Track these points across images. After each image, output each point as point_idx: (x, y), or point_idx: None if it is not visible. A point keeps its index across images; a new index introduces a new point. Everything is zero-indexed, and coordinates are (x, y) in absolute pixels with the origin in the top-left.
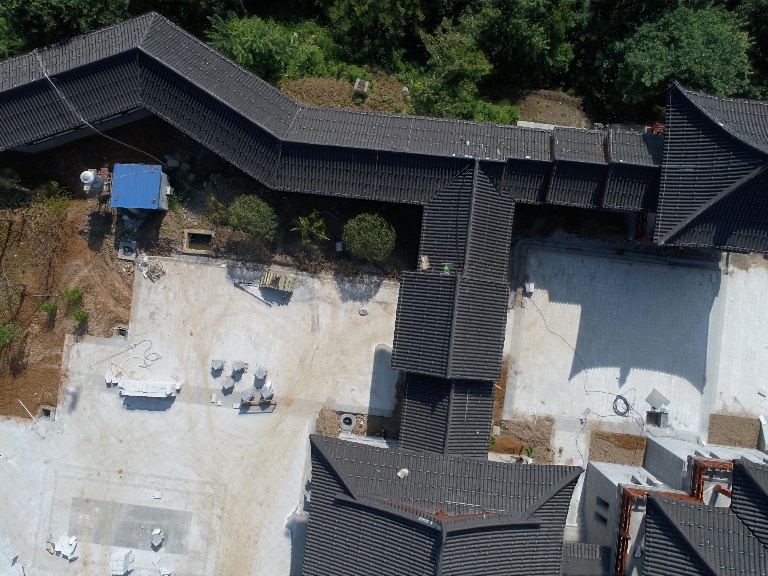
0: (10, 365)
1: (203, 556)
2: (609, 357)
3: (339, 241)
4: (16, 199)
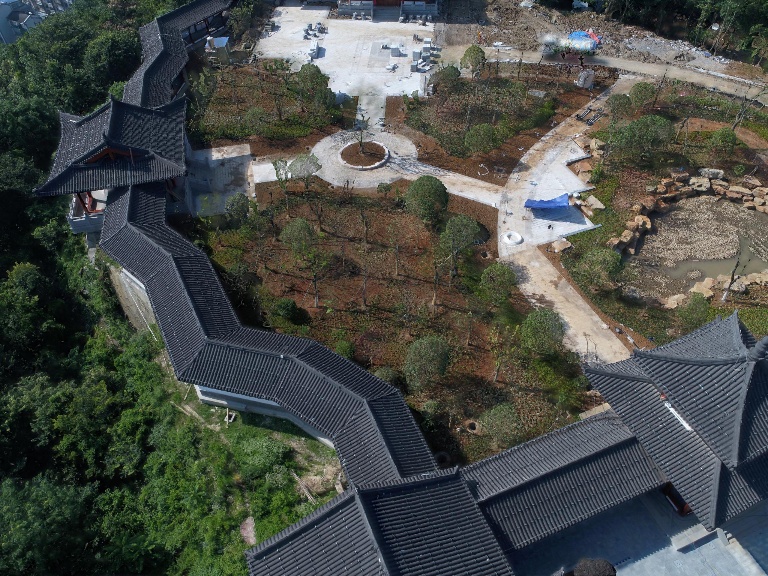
0: None
1: None
2: None
3: None
4: None
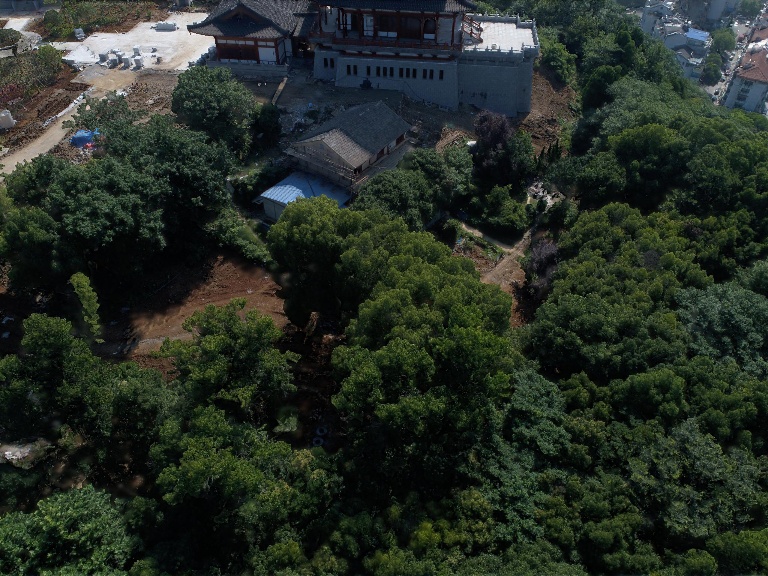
0: None
1: None
2: None
3: None
4: (137, 1)
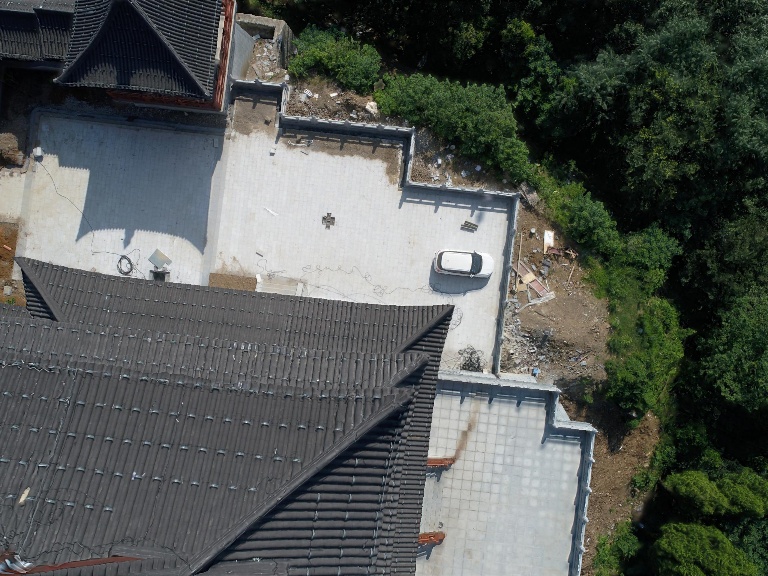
0: None
1: None
2: (115, 219)
3: None
4: None
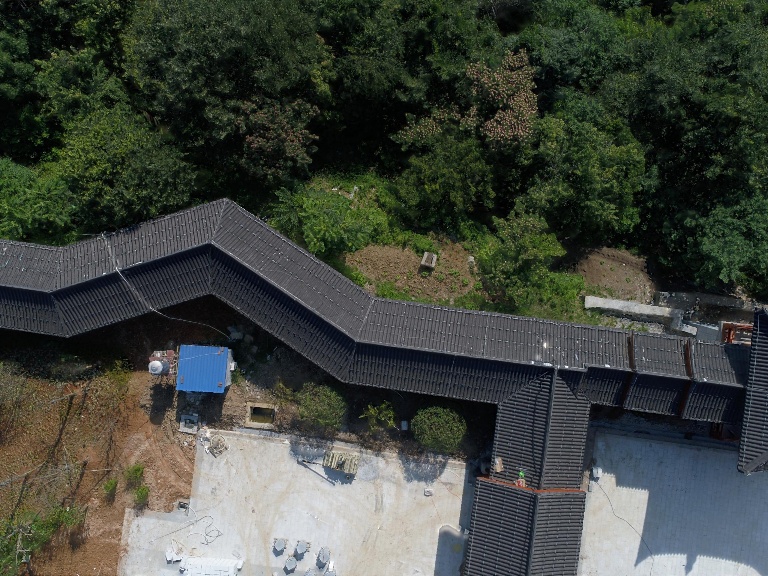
0: (69, 539)
1: None
2: (676, 544)
3: (404, 420)
4: (77, 372)
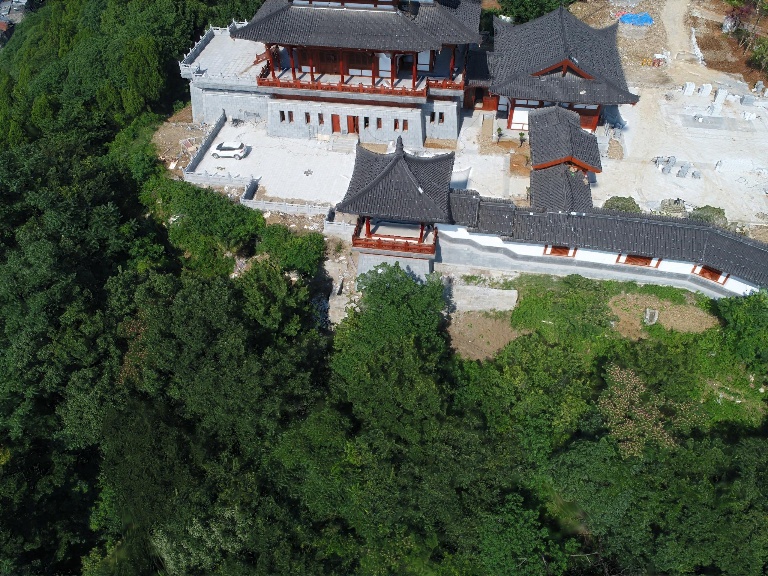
0: None
1: (669, 114)
2: None
3: None
4: None
